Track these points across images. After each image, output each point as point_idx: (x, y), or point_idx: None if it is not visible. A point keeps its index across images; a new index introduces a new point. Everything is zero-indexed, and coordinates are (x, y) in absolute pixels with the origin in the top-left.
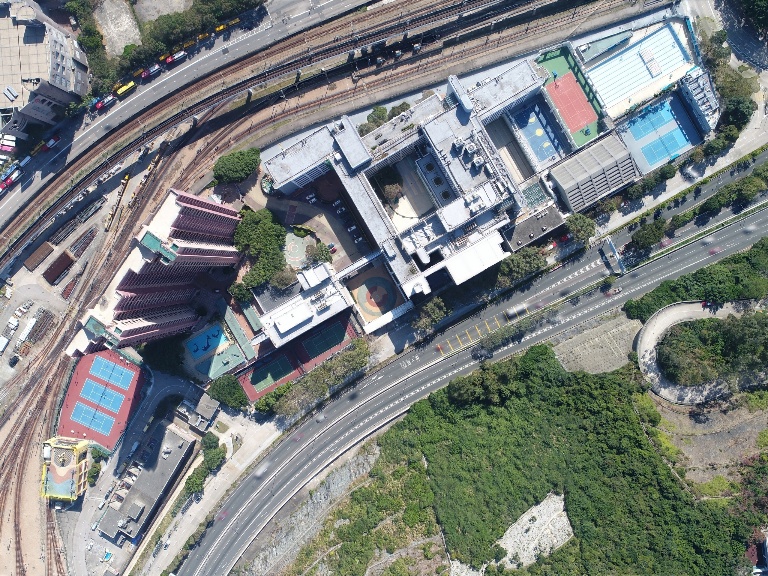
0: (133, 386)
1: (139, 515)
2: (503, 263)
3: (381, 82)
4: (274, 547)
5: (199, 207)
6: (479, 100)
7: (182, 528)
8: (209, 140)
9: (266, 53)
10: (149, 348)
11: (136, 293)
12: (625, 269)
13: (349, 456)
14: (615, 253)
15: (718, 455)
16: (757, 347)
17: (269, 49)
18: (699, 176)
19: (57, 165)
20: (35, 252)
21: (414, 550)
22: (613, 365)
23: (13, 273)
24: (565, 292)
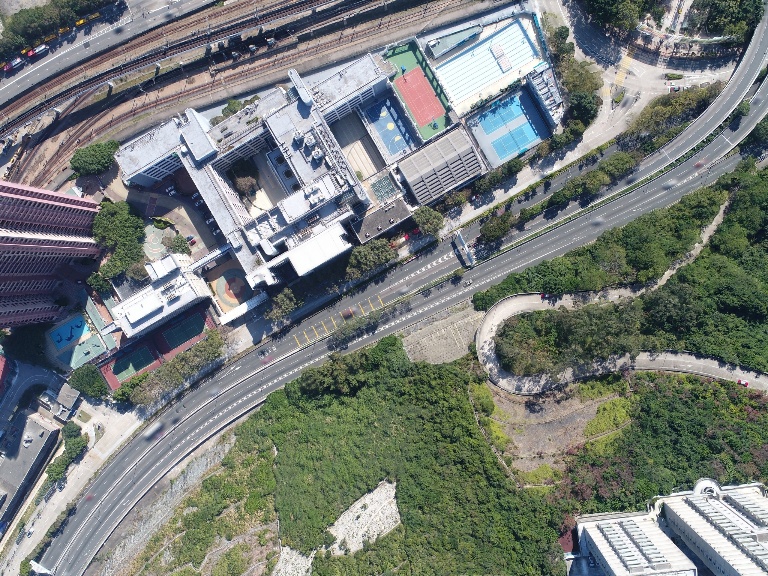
0: None
1: (1, 503)
2: (352, 255)
3: (238, 76)
4: (133, 535)
5: (30, 197)
6: (324, 94)
7: (46, 516)
8: (71, 133)
9: (126, 47)
10: (10, 338)
11: None
12: (475, 261)
13: (209, 445)
14: (464, 246)
15: (546, 444)
16: (586, 338)
17: (129, 43)
18: (548, 170)
19: None
20: None
21: (251, 537)
22: (454, 356)
23: None
24: (418, 284)
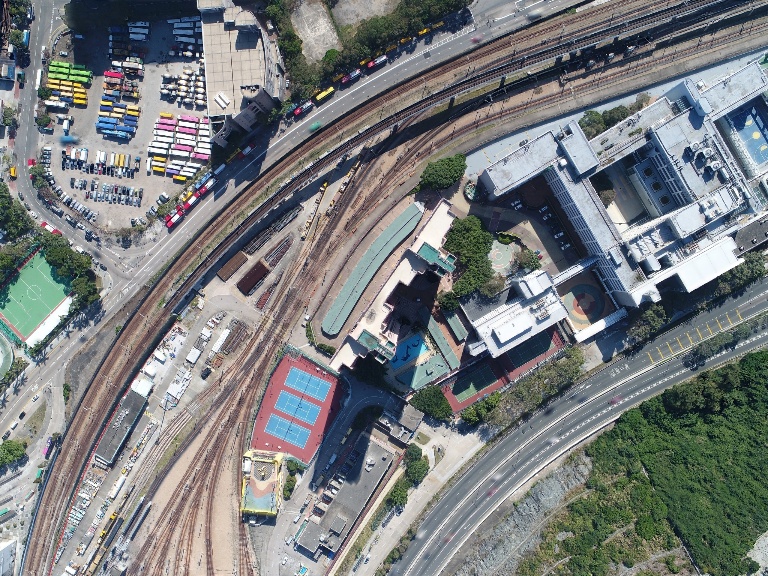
0: (330, 397)
1: None
2: None
3: (589, 85)
4: (481, 560)
5: None
6: None
7: (382, 541)
8: (410, 146)
9: (470, 57)
10: None
11: None
12: None
13: (554, 467)
14: None
15: None
16: None
17: (473, 53)
18: None
19: (251, 173)
20: (229, 262)
21: (655, 564)
22: None
23: (205, 283)
24: None
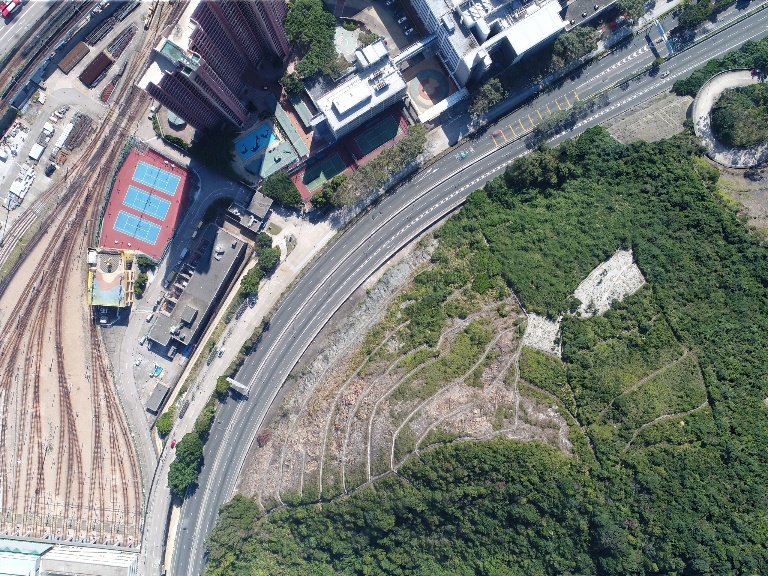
0: (179, 191)
1: (192, 320)
2: (557, 44)
3: None
4: (334, 345)
5: None
6: None
7: (236, 335)
8: None
9: None
10: (198, 144)
11: (206, 34)
12: (672, 52)
13: (405, 253)
14: (663, 35)
15: None
16: None
17: None
18: None
19: None
20: (70, 53)
21: (487, 313)
22: (669, 134)
23: (46, 77)
24: (614, 79)
